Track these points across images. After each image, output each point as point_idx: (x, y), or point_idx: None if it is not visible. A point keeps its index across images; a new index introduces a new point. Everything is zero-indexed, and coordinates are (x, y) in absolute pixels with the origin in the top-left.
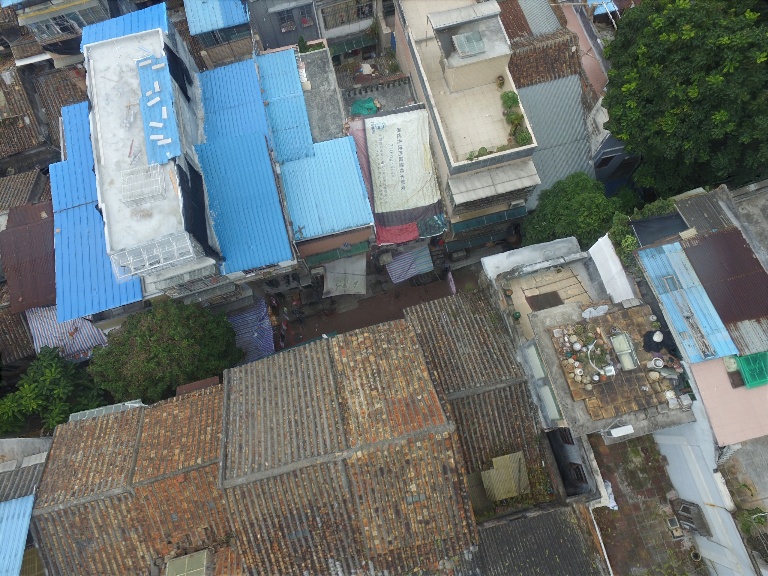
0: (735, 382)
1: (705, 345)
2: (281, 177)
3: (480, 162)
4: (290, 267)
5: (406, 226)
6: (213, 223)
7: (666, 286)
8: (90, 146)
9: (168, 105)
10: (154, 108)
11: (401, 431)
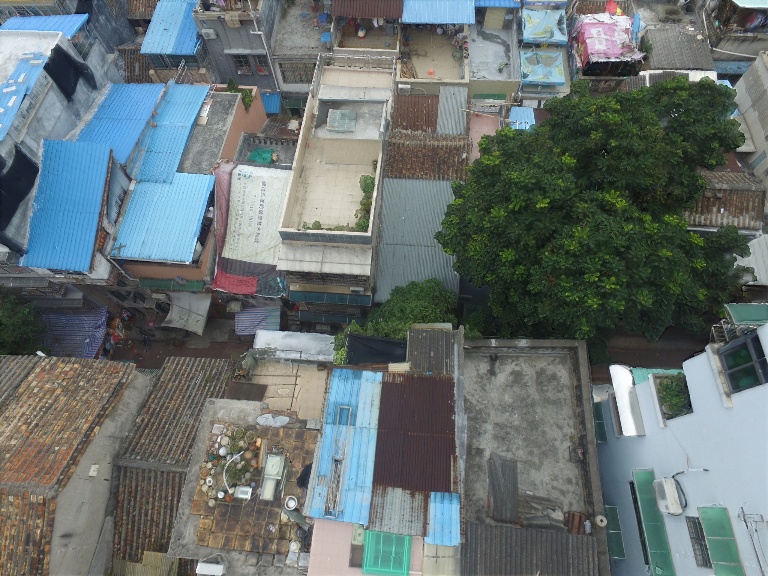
0: (354, 559)
1: (334, 500)
2: (131, 194)
3: (309, 235)
4: (104, 281)
5: (246, 279)
6: (32, 214)
7: (337, 416)
8: None
9: (20, 95)
10: (7, 95)
11: (5, 477)
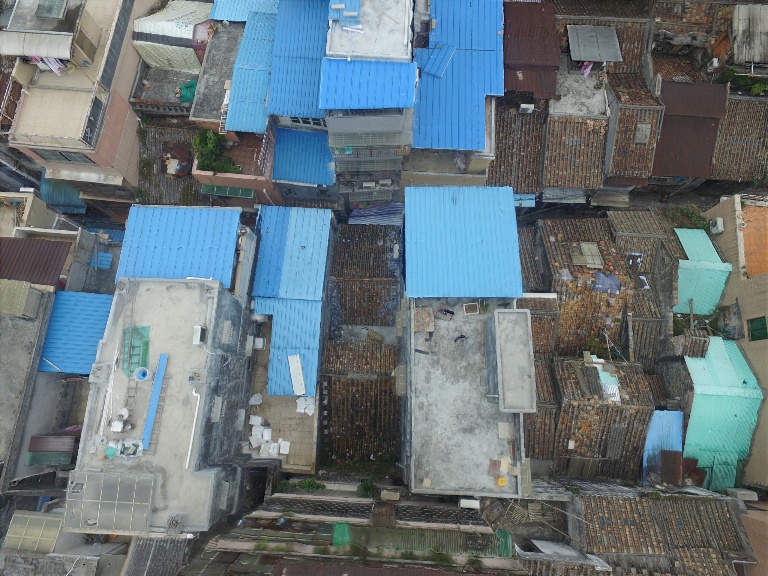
0: None
1: None
2: None
3: None
4: None
5: None
6: None
7: None
8: (460, 101)
9: None
10: None
11: None
